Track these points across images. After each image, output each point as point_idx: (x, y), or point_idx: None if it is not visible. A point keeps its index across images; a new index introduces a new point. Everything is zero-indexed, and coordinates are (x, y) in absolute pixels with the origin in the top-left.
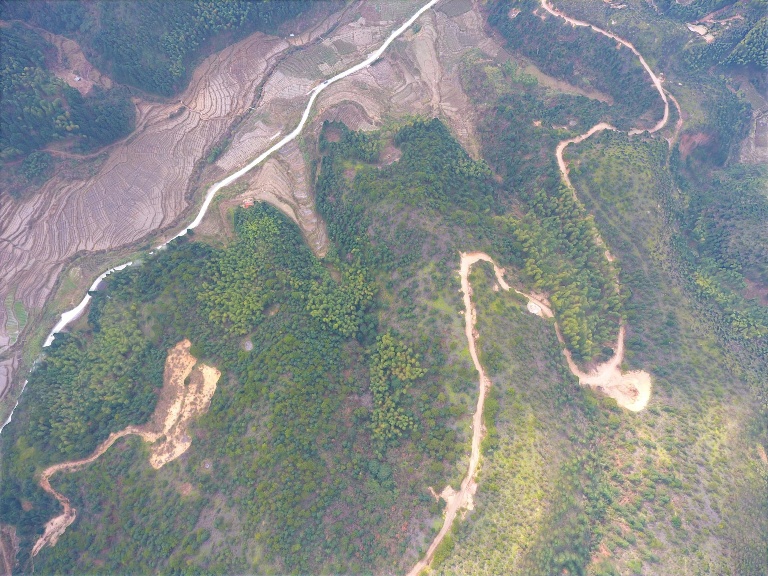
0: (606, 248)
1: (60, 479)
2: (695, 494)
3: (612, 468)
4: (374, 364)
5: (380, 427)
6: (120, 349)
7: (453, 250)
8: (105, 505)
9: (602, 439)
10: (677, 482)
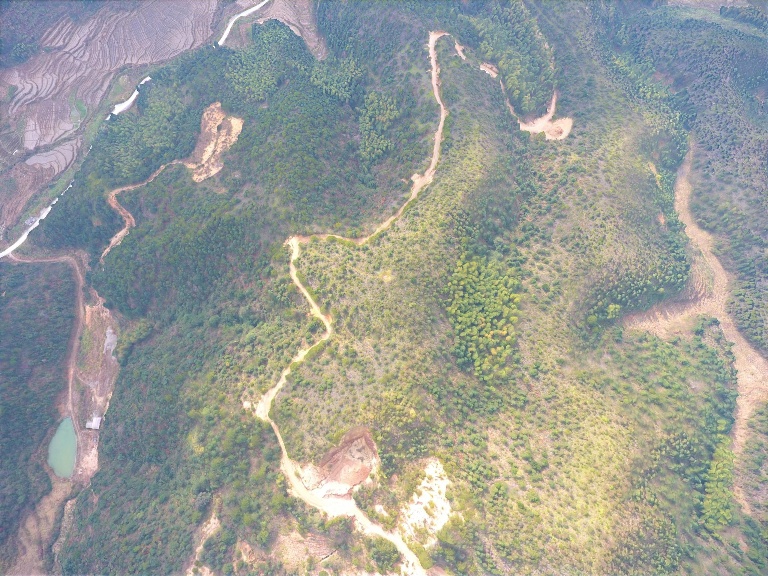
0: (545, 39)
1: (124, 195)
2: (595, 174)
3: (539, 172)
4: (362, 116)
5: (366, 151)
6: (165, 114)
7: (424, 30)
8: (160, 204)
9: (533, 158)
10: (582, 168)
